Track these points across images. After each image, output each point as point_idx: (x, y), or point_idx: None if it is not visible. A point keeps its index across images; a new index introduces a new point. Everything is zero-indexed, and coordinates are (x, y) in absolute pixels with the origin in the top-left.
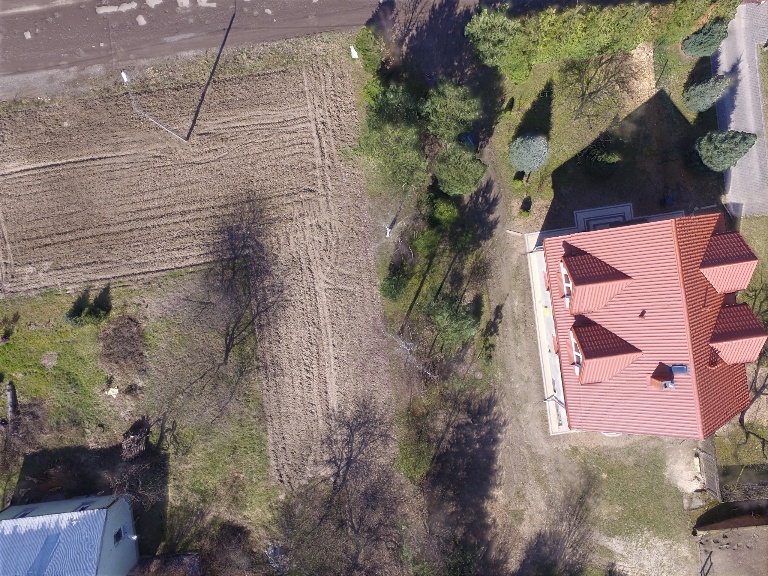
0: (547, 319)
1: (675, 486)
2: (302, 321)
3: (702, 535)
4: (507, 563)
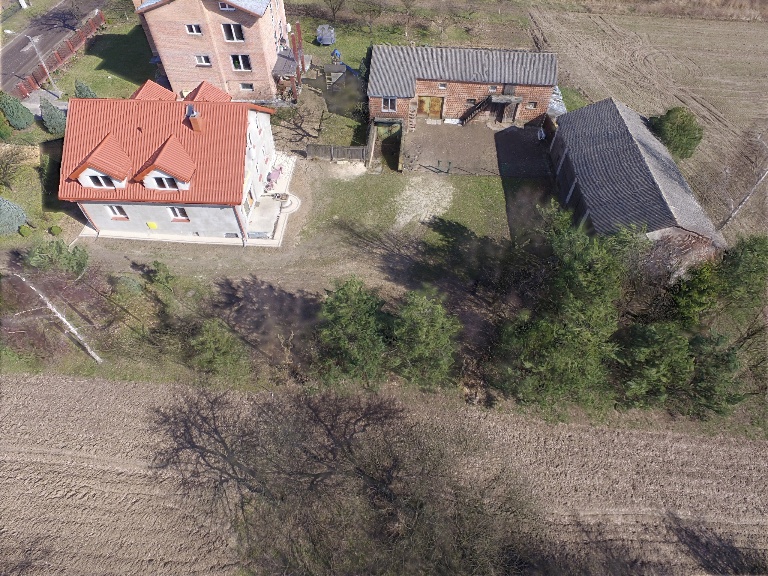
0: (160, 227)
1: (358, 177)
2: (1, 487)
3: (404, 168)
4: (406, 304)
